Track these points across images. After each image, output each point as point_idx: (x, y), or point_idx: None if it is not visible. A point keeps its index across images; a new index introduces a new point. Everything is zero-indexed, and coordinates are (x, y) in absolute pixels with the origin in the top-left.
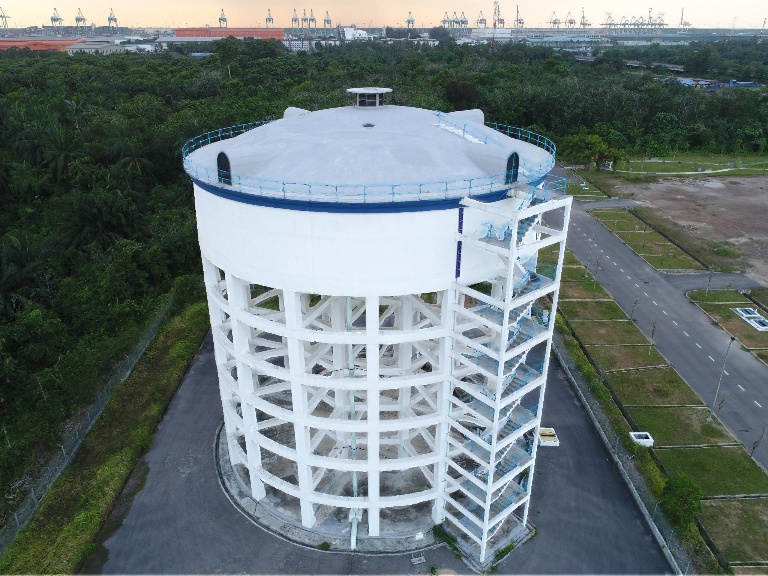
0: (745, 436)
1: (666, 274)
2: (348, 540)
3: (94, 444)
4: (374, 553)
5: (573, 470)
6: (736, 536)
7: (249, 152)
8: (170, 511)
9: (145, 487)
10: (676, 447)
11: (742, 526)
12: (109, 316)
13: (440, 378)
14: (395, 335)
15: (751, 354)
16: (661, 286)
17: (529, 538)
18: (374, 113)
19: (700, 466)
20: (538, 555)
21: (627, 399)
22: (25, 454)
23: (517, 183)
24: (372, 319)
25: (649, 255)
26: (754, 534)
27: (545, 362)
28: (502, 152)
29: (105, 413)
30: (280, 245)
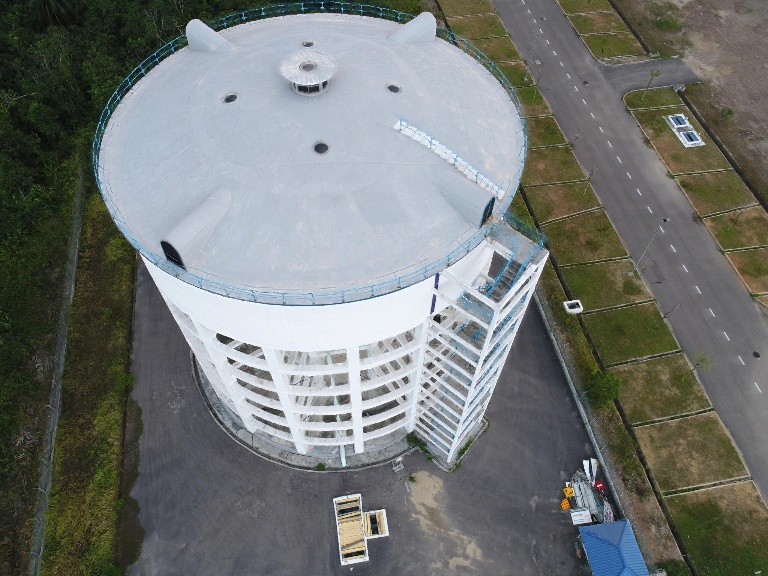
0: (658, 289)
1: (606, 66)
2: (338, 458)
3: (75, 386)
4: (362, 466)
5: (516, 353)
6: (640, 399)
7: (196, 229)
8: (177, 452)
9: (144, 430)
10: (601, 310)
11: (645, 388)
12: (20, 213)
13: (414, 370)
14: (375, 363)
15: (675, 182)
16: (600, 87)
17: (483, 431)
18: (320, 110)
19: (619, 330)
20: (491, 446)
21: (562, 257)
22: (13, 413)
23: (492, 220)
24: (353, 359)
25: (590, 35)
26: (653, 395)
27: (508, 348)
28: (478, 199)
29: (70, 345)
30: (253, 322)
